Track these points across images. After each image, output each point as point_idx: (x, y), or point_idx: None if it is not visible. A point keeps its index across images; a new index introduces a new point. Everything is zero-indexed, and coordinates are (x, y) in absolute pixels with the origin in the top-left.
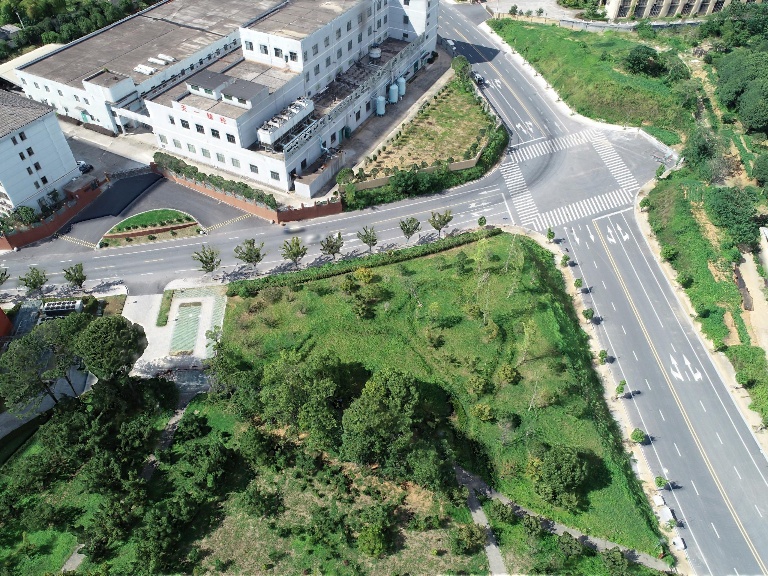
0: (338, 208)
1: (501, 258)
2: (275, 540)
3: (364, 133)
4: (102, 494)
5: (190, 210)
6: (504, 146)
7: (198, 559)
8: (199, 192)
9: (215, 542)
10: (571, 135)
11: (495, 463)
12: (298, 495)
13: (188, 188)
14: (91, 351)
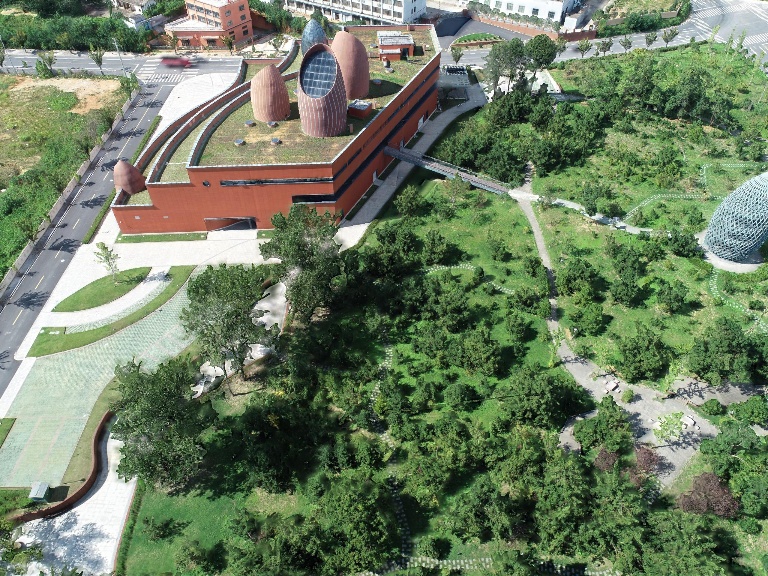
0: (593, 35)
1: (717, 49)
2: (640, 140)
3: (591, 1)
4: (541, 124)
5: (498, 34)
6: (690, 10)
7: (603, 145)
8: (498, 27)
9: (608, 141)
10: (734, 6)
11: (743, 124)
12: (643, 128)
13: (490, 24)
14: (539, 48)
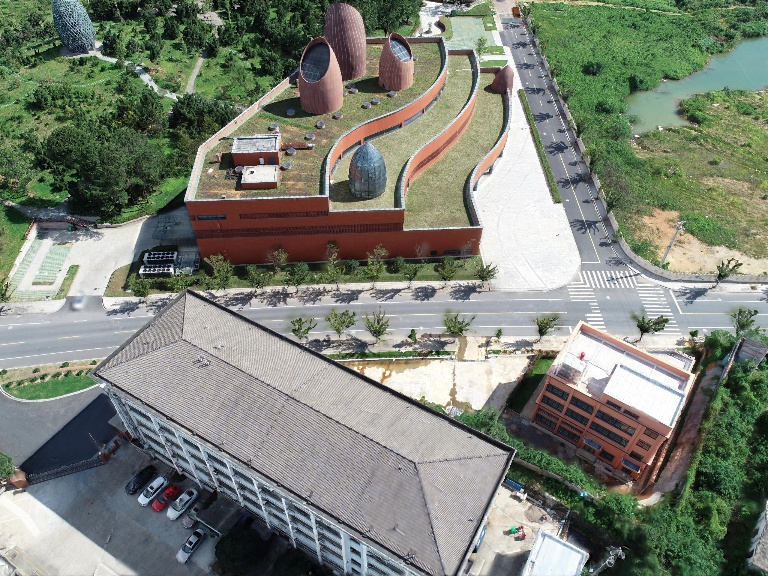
0: None
1: None
2: None
3: None
4: None
5: (1, 402)
6: None
7: None
8: None
9: None
10: None
11: None
12: None
13: None
14: None
